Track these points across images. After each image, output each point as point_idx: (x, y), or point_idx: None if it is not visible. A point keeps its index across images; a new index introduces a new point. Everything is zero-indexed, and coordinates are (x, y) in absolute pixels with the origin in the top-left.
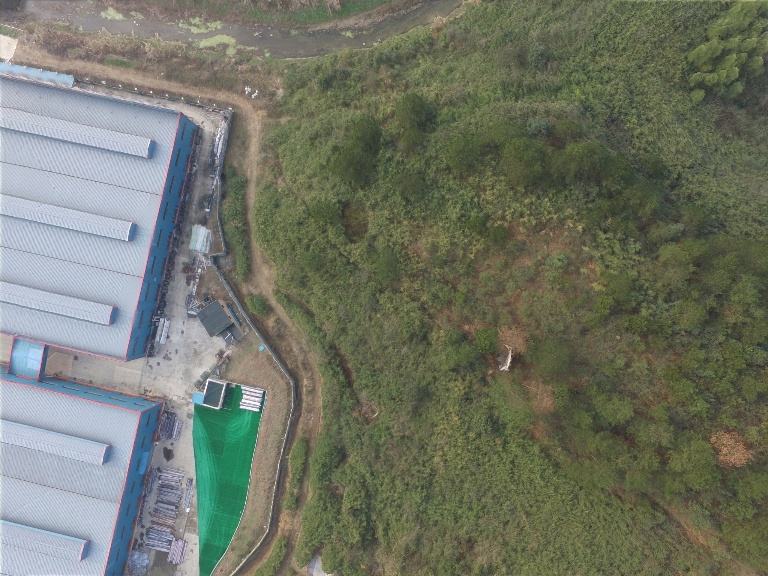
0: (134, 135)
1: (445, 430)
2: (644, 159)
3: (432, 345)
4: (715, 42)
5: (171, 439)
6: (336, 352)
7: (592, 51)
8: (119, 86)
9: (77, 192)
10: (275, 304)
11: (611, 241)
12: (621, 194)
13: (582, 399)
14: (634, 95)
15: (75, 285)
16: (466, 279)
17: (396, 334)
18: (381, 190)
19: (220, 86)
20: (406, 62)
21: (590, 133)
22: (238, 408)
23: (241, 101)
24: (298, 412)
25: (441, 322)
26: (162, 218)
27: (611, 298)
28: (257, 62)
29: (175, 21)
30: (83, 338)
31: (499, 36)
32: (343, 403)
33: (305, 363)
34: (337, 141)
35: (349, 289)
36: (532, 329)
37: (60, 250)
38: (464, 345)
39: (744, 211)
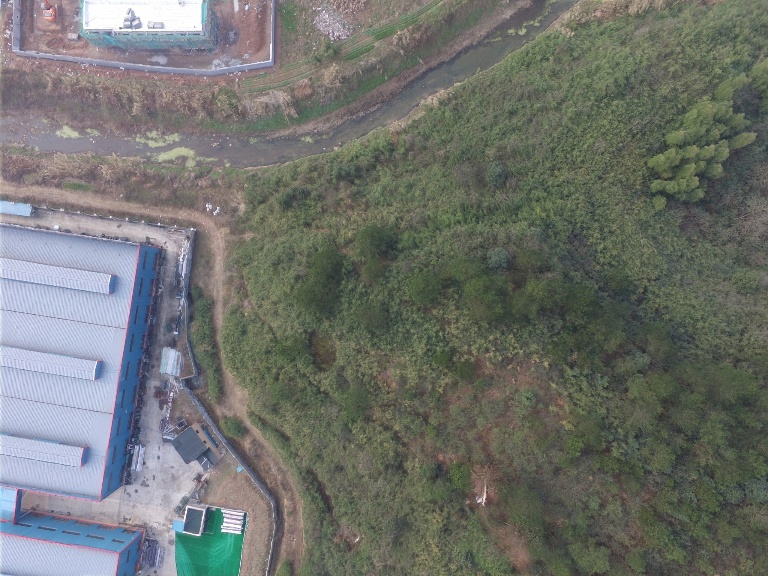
0: (94, 272)
1: (426, 561)
2: (609, 276)
3: (408, 474)
4: (673, 151)
5: (154, 567)
6: (313, 477)
7: (550, 166)
8: (78, 211)
9: (40, 330)
10: (250, 425)
11: (578, 379)
12: (585, 329)
13: (558, 544)
14: (595, 207)
15: (44, 426)
16: (437, 412)
17: (371, 464)
18: (346, 321)
19: (181, 204)
20: (366, 174)
21: (552, 255)
22: (220, 531)
23: (203, 218)
24: (281, 532)
25: (415, 452)
26: (129, 351)
27: (581, 441)
28: (217, 174)
29: (132, 136)
30: (56, 479)
31: (456, 152)
32: (323, 530)
33: (284, 483)
34: (299, 269)
35: (321, 417)
36: (505, 466)
37: (27, 391)
38: (438, 482)
39: (713, 323)
